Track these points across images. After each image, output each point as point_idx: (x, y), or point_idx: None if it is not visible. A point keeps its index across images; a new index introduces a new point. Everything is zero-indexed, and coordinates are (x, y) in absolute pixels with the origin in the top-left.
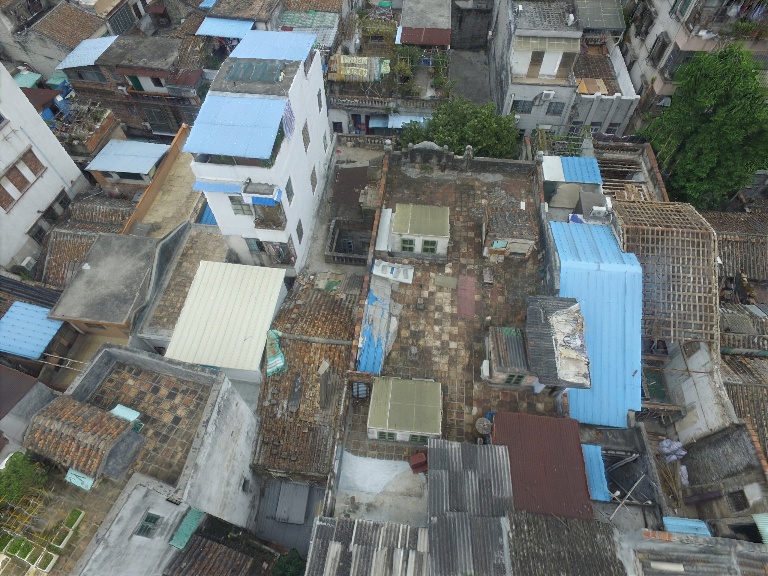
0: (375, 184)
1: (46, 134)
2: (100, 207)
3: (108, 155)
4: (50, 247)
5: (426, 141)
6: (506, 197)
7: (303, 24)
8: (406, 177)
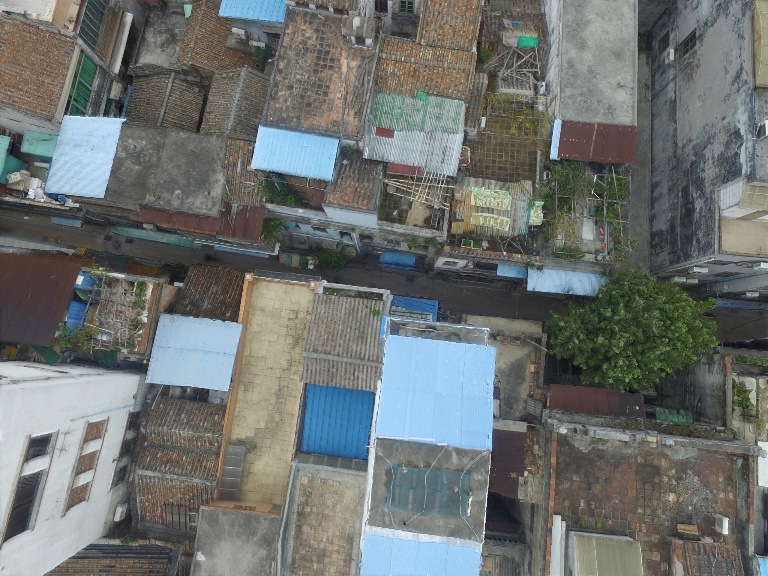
0: (533, 457)
1: (97, 390)
2: (180, 432)
3: (167, 350)
4: (137, 488)
5: (614, 432)
6: (700, 489)
7: (409, 123)
8: (574, 450)
